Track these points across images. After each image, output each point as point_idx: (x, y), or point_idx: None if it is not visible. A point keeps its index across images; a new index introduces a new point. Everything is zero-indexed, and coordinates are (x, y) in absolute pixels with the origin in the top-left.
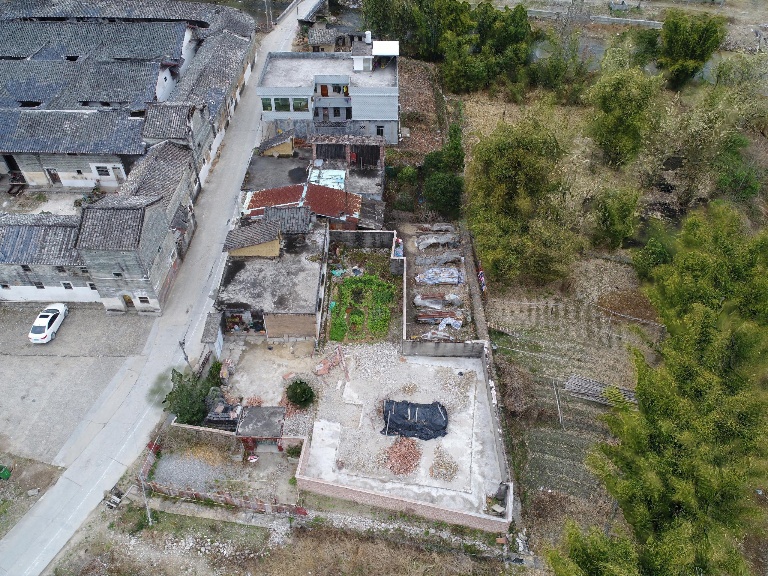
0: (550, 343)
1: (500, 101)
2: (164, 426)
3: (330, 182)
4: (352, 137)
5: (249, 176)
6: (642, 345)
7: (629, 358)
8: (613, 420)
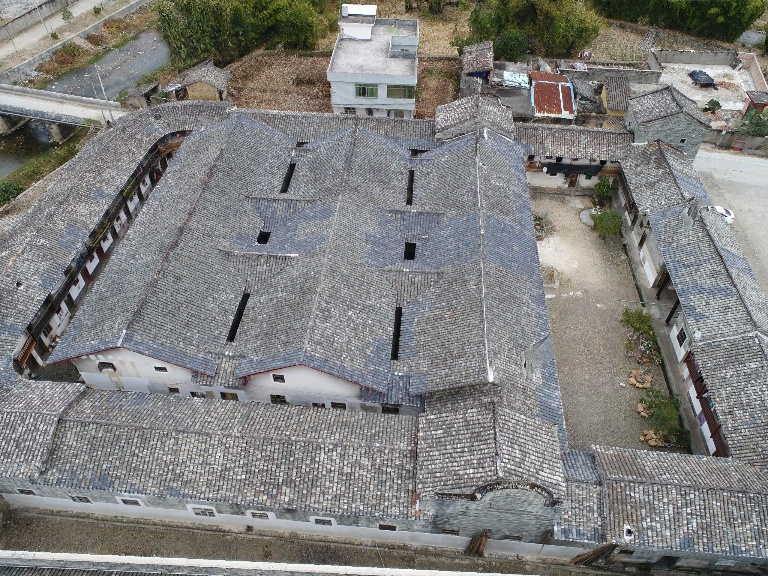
0: (618, 51)
1: (330, 36)
2: (762, 153)
3: (520, 78)
4: (472, 56)
5: (514, 114)
6: (609, 31)
7: (619, 35)
8: (715, 8)
